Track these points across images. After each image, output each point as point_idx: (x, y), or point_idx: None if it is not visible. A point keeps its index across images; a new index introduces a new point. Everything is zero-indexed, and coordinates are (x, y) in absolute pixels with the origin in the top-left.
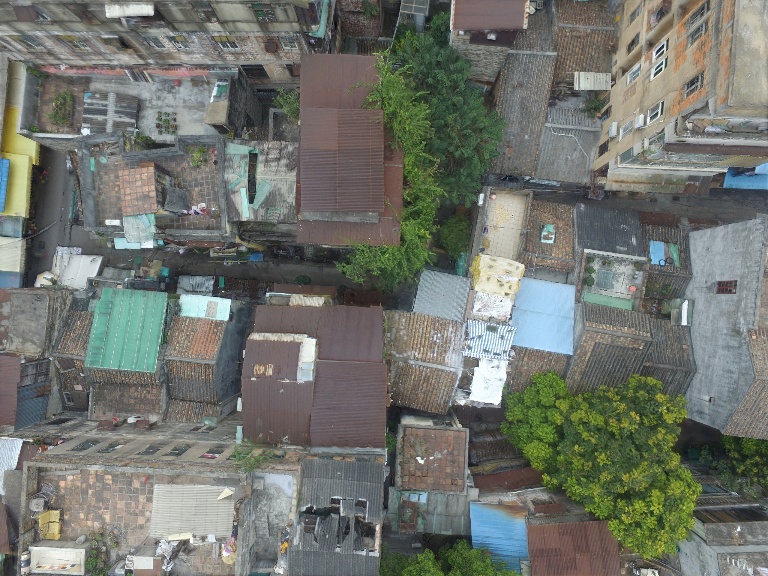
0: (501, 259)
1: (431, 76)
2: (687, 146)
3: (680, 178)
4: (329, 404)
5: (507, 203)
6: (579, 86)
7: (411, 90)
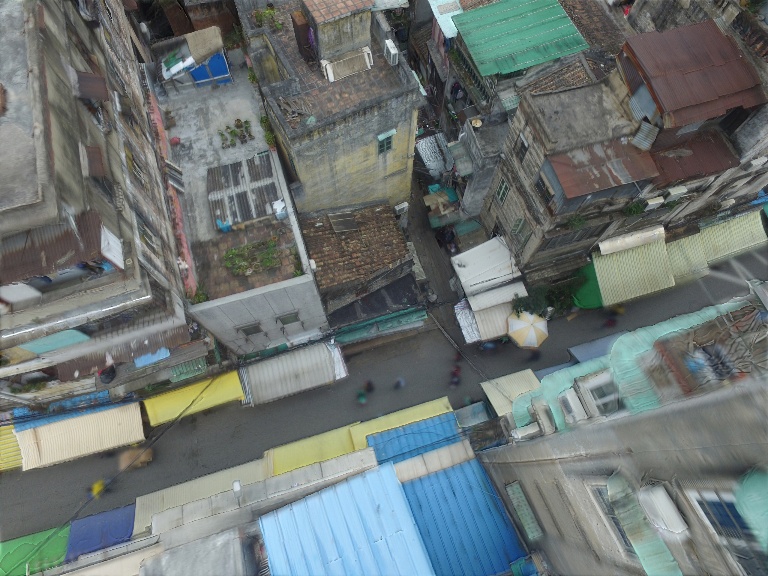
0: None
1: None
2: None
3: None
4: None
5: None
6: None
7: None
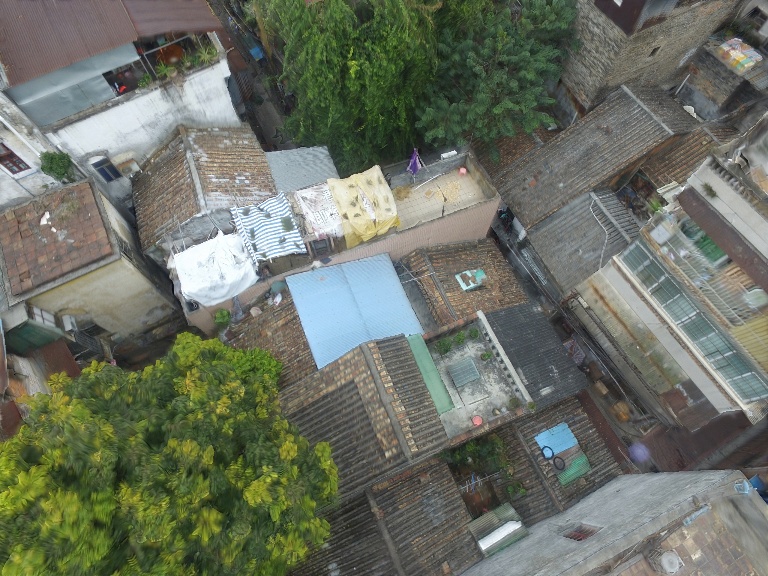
0: (387, 187)
1: (531, 1)
2: (712, 215)
3: (675, 370)
4: (51, 2)
5: (467, 191)
6: (665, 192)
7: (503, 4)
